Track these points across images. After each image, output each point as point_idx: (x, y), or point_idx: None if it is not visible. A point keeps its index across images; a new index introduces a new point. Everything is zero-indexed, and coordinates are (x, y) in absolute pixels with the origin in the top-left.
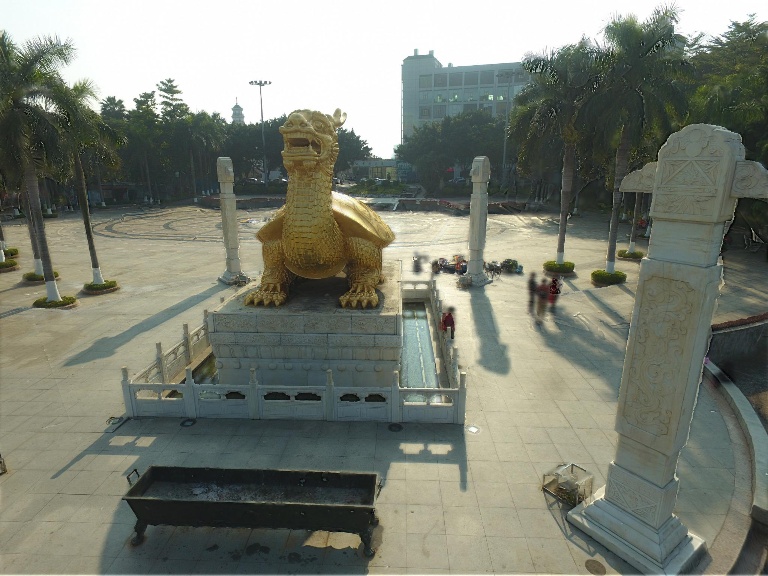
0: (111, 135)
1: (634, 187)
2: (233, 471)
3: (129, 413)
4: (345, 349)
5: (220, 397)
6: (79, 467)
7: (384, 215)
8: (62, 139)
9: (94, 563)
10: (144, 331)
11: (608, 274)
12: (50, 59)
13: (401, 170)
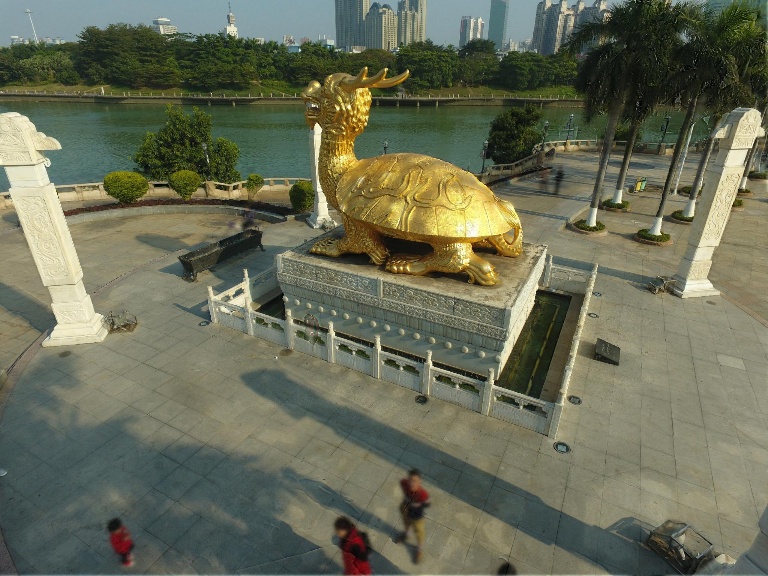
0: None
1: (52, 146)
2: (239, 242)
3: None
4: None
5: None
6: None
7: None
8: None
9: None
10: None
11: None
12: None
13: None
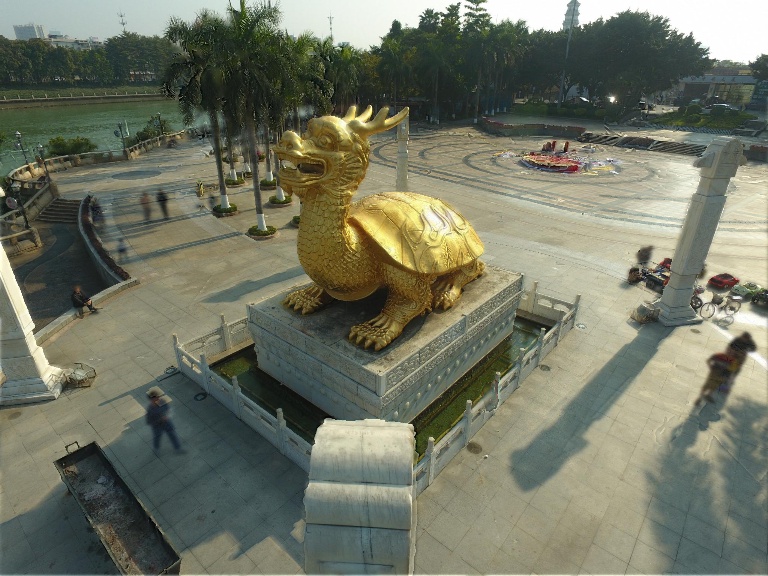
0: (320, 86)
1: None
2: (121, 479)
3: (180, 368)
4: (335, 384)
5: (254, 377)
6: (116, 404)
7: (678, 163)
8: (275, 94)
9: (43, 493)
10: (275, 282)
11: None
12: (264, 22)
13: (750, 94)
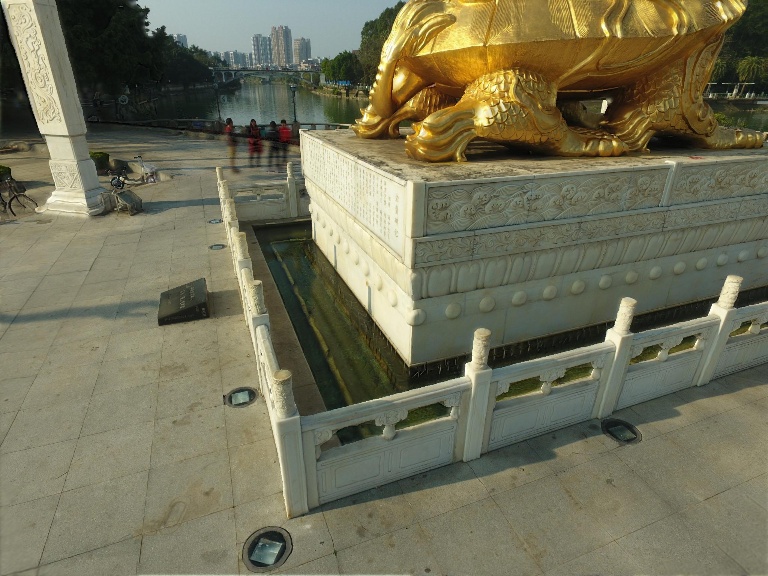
0: None
1: None
2: None
3: None
4: None
5: None
6: None
7: None
8: None
9: None
10: None
11: (100, 154)
12: None
13: None
